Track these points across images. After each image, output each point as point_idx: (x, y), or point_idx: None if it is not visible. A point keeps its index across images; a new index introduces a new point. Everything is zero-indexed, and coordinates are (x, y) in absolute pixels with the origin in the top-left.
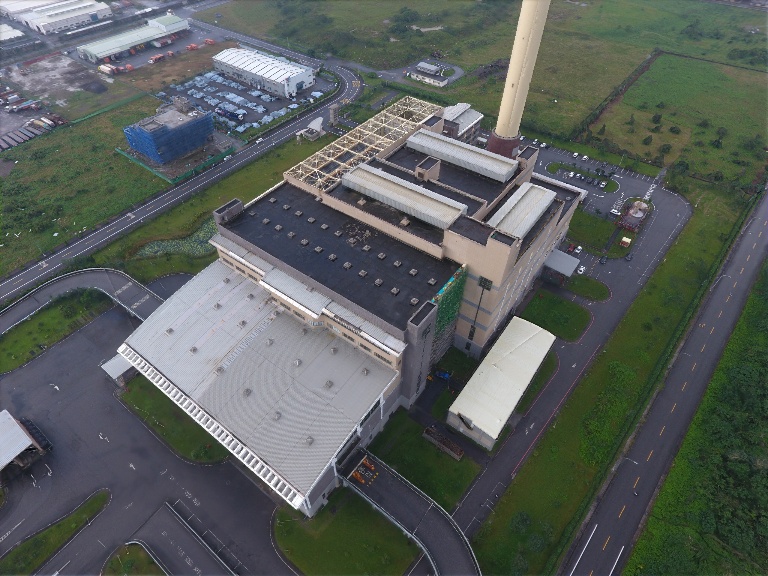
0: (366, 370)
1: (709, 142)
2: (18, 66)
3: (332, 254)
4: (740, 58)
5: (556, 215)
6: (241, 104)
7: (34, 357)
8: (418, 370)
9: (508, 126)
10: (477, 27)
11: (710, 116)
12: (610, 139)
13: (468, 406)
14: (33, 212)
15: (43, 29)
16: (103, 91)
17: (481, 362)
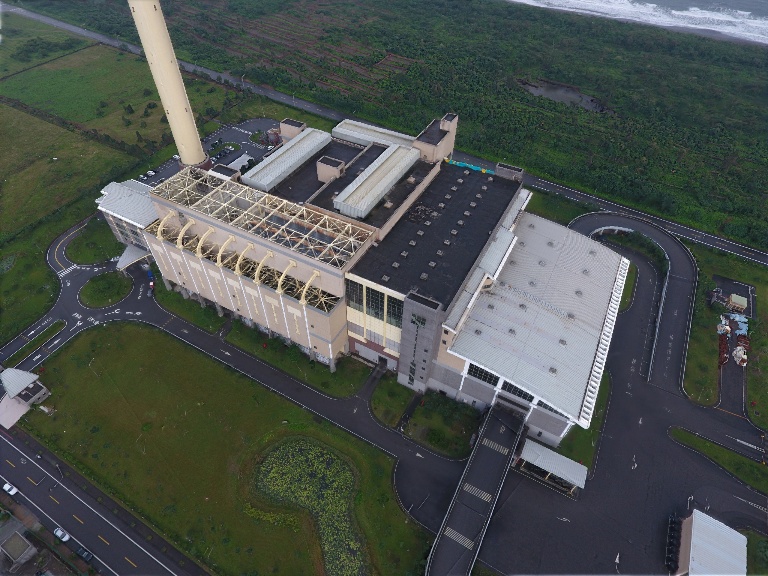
0: (532, 225)
1: None
2: None
3: (460, 221)
4: (29, 58)
5: None
6: None
7: None
8: None
9: (201, 148)
10: None
11: (133, 89)
12: None
13: None
14: None
15: None
16: None
17: None
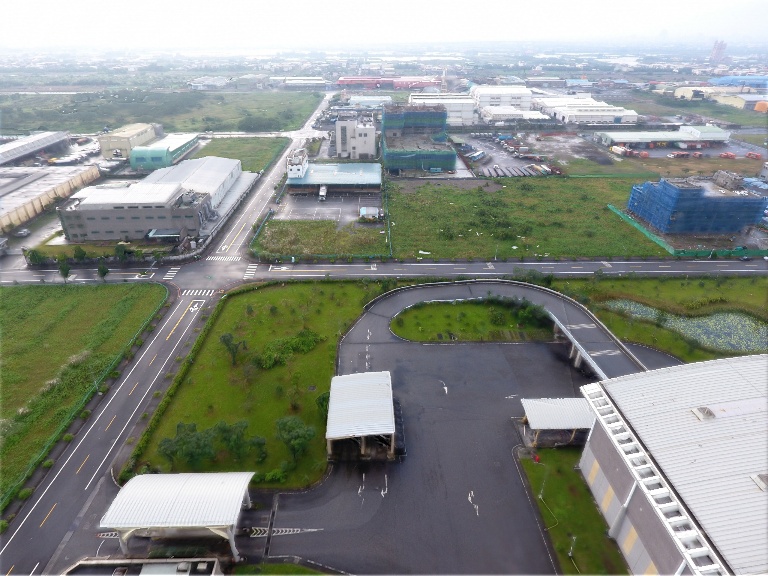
0: None
1: None
2: (536, 135)
3: None
4: None
5: None
6: None
7: (439, 341)
8: None
9: None
10: None
11: None
12: None
13: None
14: (504, 221)
15: (568, 119)
16: (608, 164)
17: None
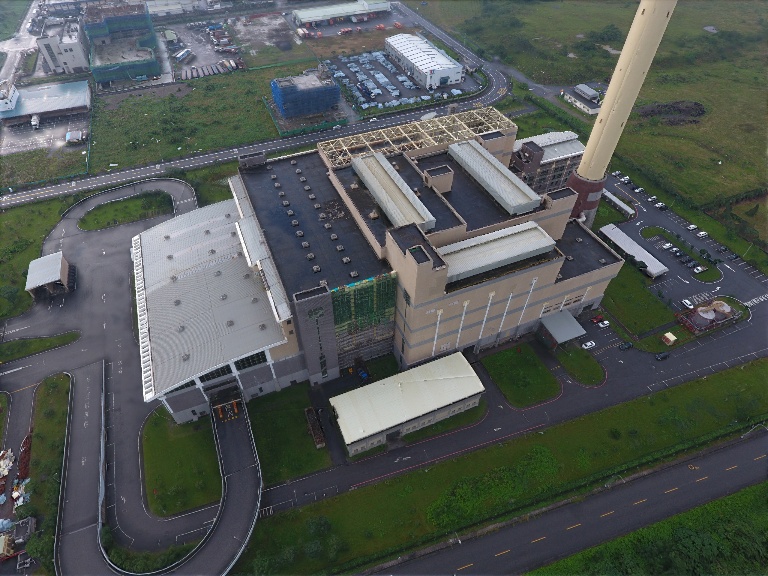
0: (262, 326)
1: None
2: (246, 18)
3: (295, 220)
4: None
5: (545, 266)
6: (383, 85)
7: (107, 227)
8: (316, 350)
9: (589, 166)
10: (686, 61)
11: None
12: (755, 224)
13: (346, 404)
14: (176, 127)
15: None
16: (288, 50)
17: (391, 375)
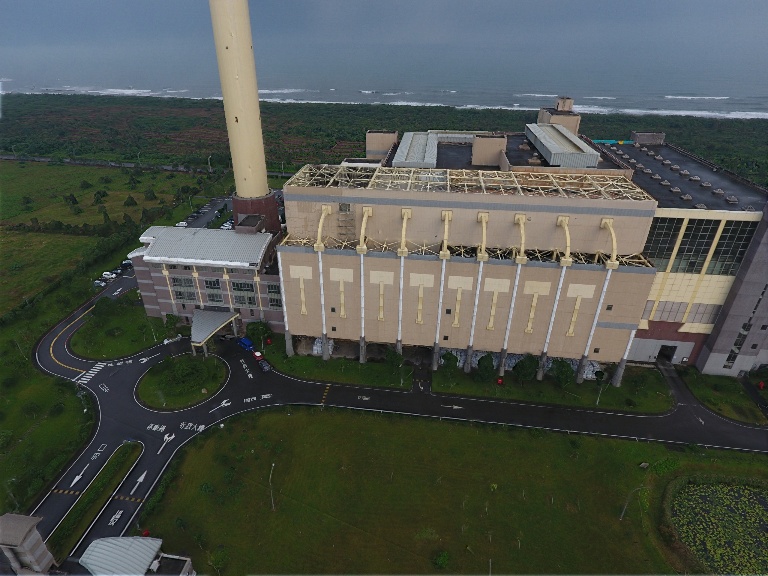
0: None
1: (128, 185)
2: None
3: (676, 165)
4: None
5: None
6: None
7: None
8: None
9: None
10: None
11: (61, 185)
12: None
13: None
14: None
15: None
16: None
17: None
